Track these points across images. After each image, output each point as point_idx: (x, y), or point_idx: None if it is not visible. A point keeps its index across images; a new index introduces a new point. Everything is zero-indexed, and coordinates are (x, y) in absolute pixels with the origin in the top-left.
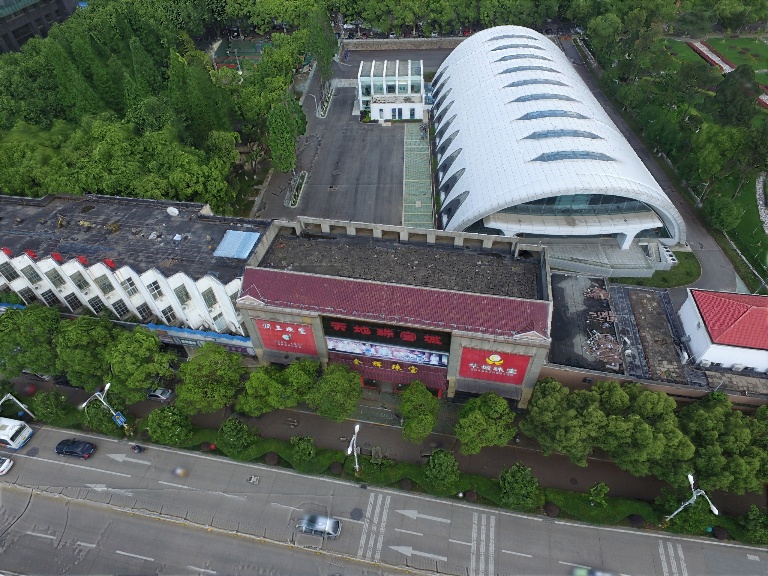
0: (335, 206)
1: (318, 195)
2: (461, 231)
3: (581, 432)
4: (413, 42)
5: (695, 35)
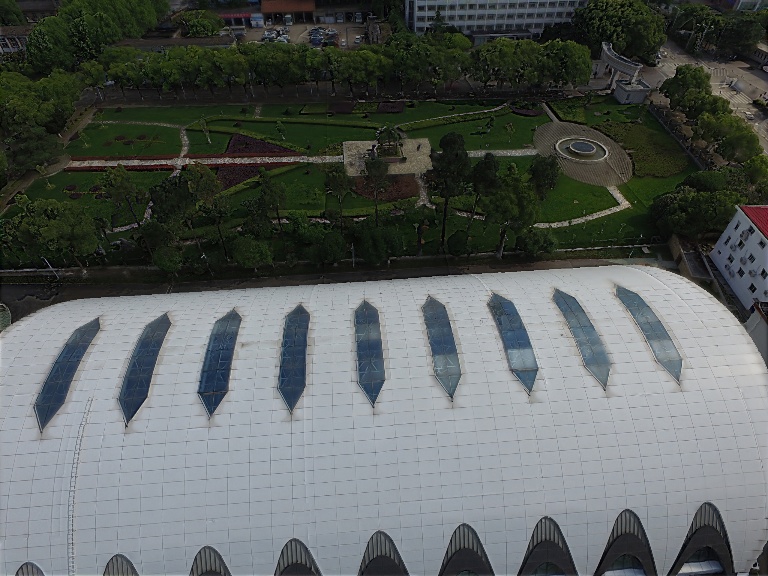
0: None
1: None
2: None
3: None
4: None
5: (49, 158)
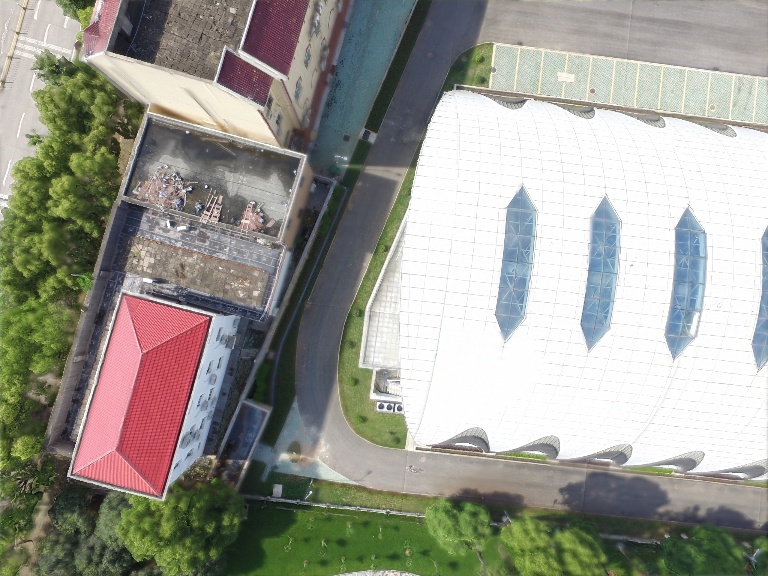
0: None
1: None
2: None
3: (40, 105)
4: None
5: None
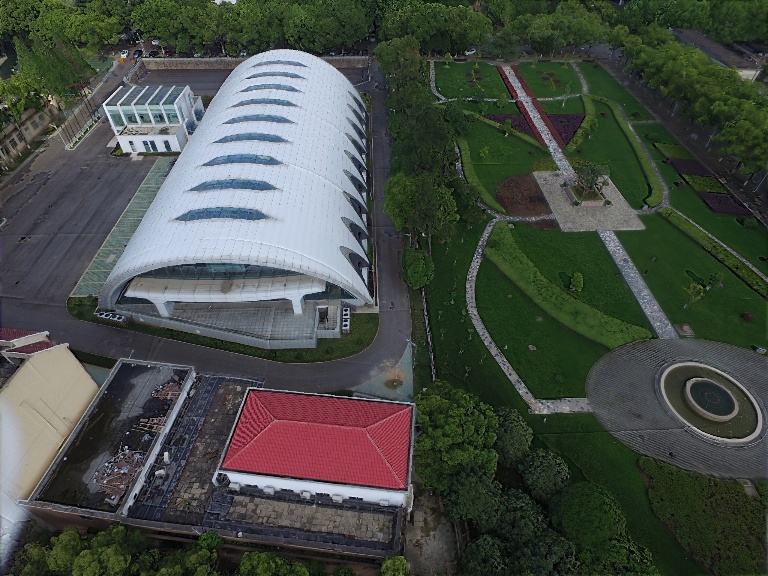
0: (11, 263)
1: (1, 249)
2: (116, 297)
3: None
4: (220, 62)
5: (508, 59)
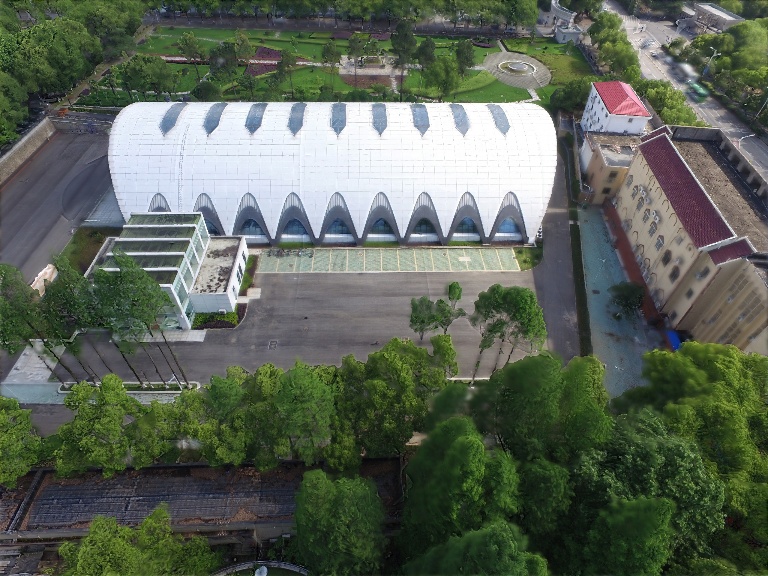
0: None
1: (466, 357)
2: None
3: None
4: None
5: None
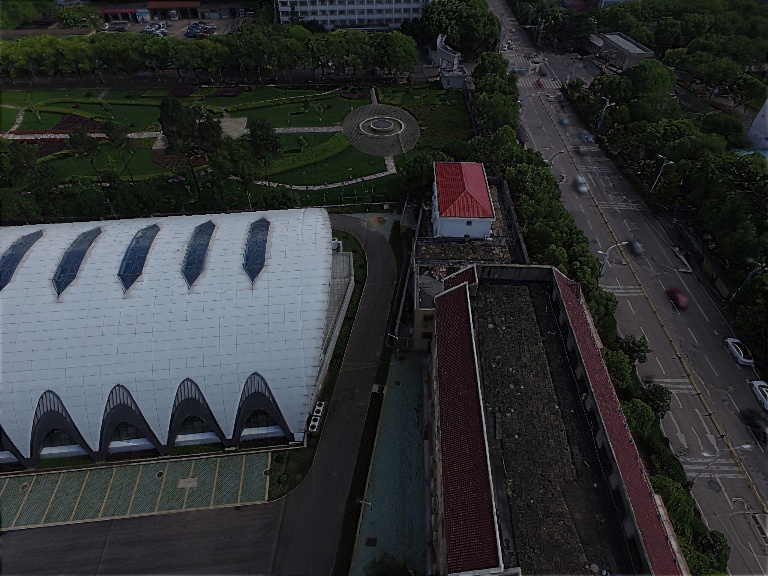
0: None
1: None
2: None
3: None
4: None
5: None
